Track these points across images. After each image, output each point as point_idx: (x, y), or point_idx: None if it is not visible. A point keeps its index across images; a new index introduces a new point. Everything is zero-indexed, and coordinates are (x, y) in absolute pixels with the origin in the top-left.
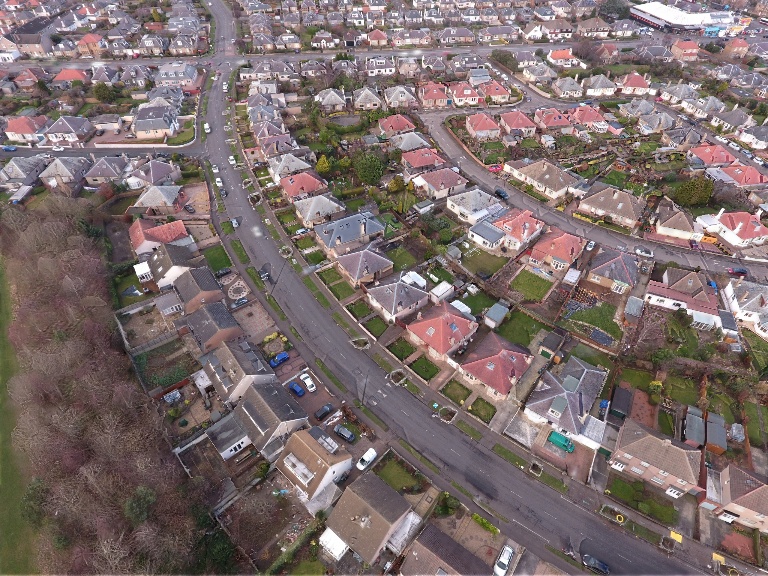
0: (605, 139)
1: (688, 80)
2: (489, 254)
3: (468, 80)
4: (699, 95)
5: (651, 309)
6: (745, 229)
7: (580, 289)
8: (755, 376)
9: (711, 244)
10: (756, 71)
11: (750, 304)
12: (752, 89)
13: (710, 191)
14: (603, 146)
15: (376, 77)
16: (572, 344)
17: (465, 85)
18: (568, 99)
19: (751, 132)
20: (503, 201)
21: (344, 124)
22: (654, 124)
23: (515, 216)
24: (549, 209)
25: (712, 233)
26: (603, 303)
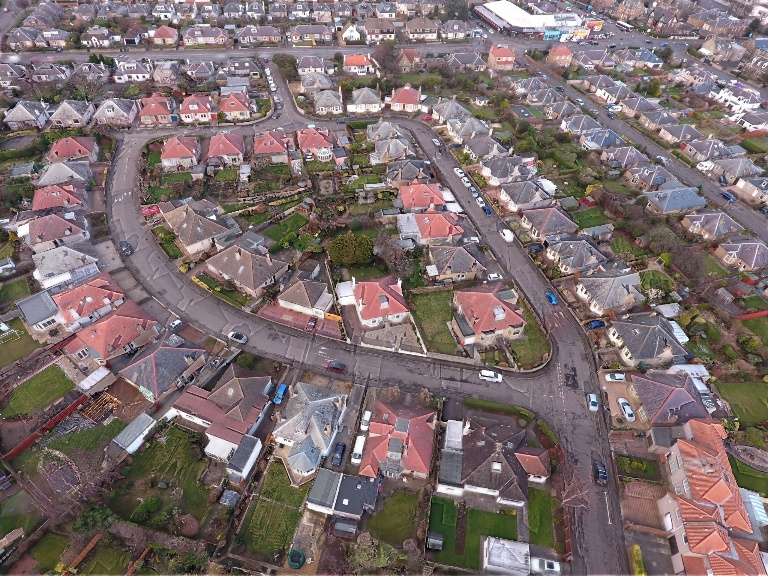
0: (316, 171)
1: (482, 94)
2: (30, 339)
3: (220, 91)
4: (471, 114)
5: (173, 429)
6: (369, 306)
7: (102, 396)
8: (199, 555)
9: (336, 322)
10: (569, 84)
11: (284, 427)
12: (542, 107)
13: (366, 249)
14: (303, 181)
15: (114, 85)
16: (8, 492)
17: (192, 99)
18: (322, 116)
19: (489, 165)
20: (119, 258)
21: (20, 146)
22: (381, 153)
23: (74, 288)
24: (172, 269)
25: (348, 306)
26: (114, 419)
